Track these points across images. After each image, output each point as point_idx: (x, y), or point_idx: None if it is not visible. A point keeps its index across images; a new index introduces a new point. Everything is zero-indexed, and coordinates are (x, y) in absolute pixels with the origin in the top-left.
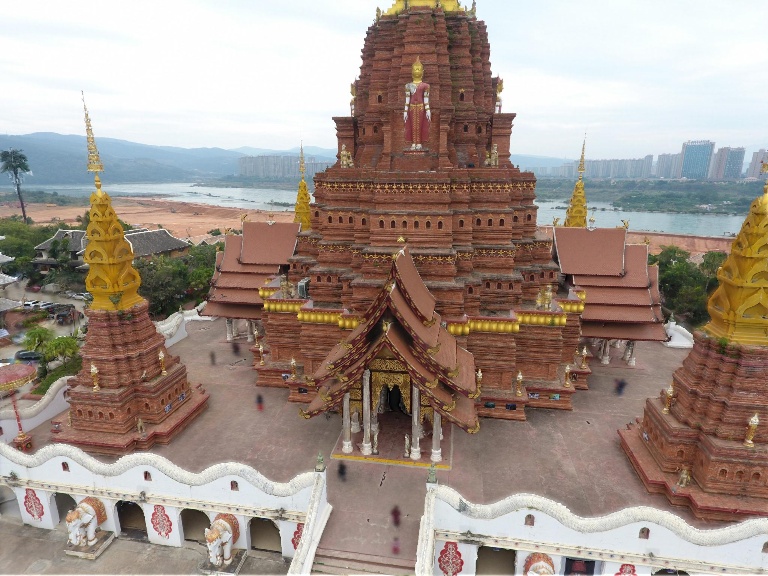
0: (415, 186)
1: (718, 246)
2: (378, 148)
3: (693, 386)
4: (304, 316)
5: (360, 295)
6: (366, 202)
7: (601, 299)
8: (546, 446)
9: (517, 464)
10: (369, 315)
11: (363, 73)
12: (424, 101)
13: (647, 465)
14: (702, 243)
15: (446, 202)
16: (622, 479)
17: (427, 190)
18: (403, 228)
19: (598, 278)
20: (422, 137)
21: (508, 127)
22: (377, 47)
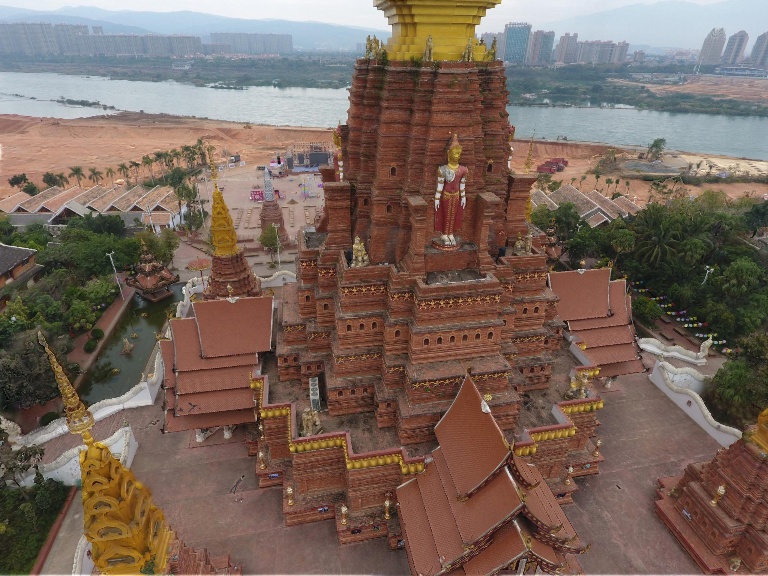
0: (465, 299)
1: (555, 151)
2: (392, 230)
3: (747, 492)
4: (354, 464)
5: (411, 424)
6: (399, 312)
7: (594, 342)
8: (606, 535)
9: (598, 573)
10: (472, 494)
11: (356, 123)
12: (460, 187)
13: (700, 549)
14: (543, 148)
15: (497, 312)
16: (680, 563)
17: (478, 302)
18: (450, 343)
19: (589, 320)
20: (455, 226)
21: (526, 190)
22: (389, 106)
